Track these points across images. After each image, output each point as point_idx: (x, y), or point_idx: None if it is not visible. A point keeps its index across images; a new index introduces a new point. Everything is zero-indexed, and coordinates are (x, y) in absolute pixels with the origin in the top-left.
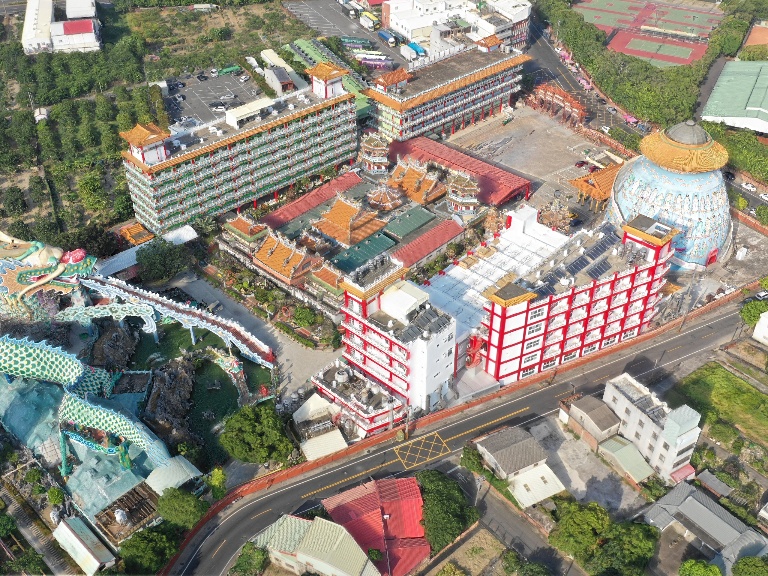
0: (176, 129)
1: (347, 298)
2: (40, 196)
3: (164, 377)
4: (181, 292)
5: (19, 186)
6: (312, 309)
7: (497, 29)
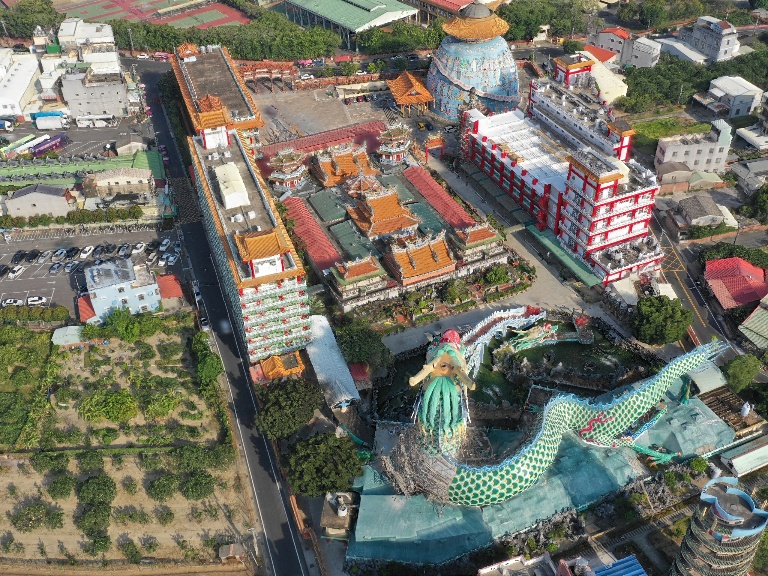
0: (102, 286)
1: (599, 192)
2: (97, 458)
3: (555, 372)
4: (397, 356)
5: (26, 490)
6: (489, 269)
7: (118, 54)
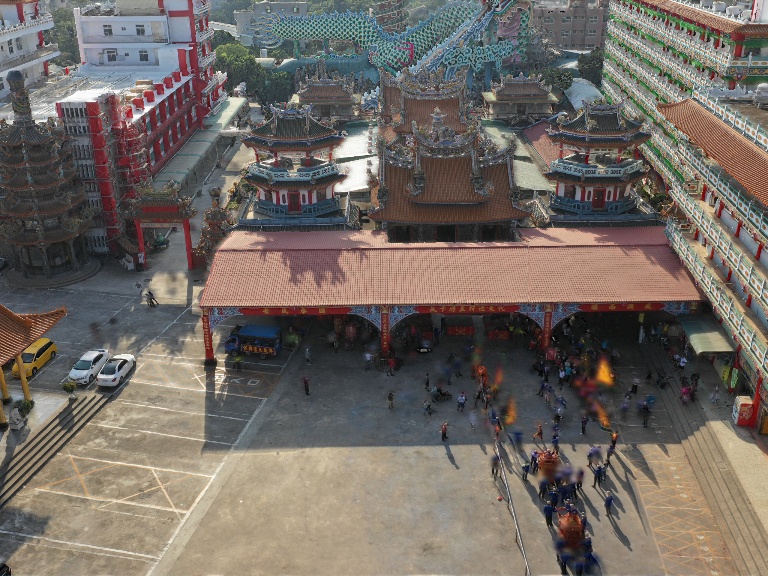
0: None
1: None
2: None
3: None
4: None
5: None
6: None
7: None
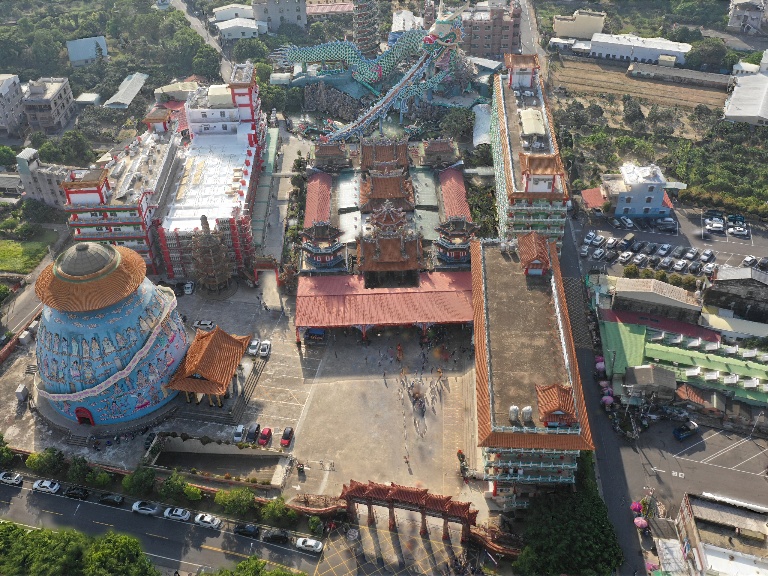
0: (648, 167)
1: None
2: None
3: None
4: None
5: (677, 129)
6: None
7: None
